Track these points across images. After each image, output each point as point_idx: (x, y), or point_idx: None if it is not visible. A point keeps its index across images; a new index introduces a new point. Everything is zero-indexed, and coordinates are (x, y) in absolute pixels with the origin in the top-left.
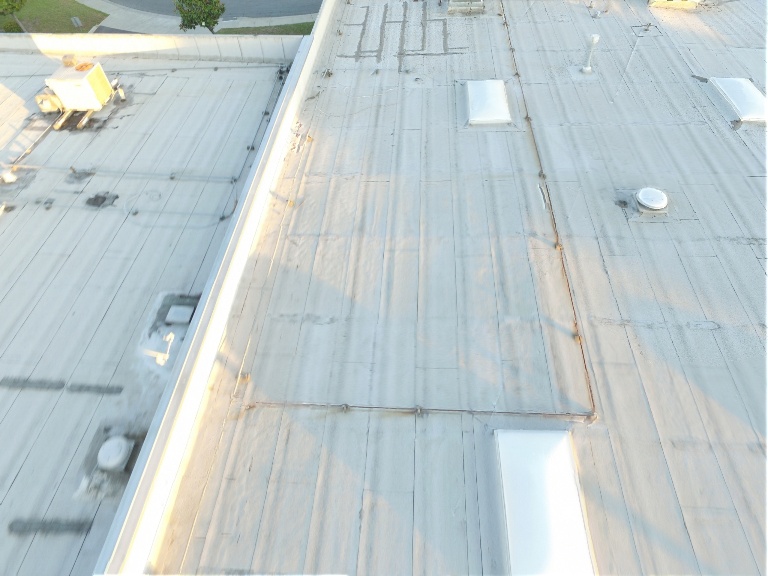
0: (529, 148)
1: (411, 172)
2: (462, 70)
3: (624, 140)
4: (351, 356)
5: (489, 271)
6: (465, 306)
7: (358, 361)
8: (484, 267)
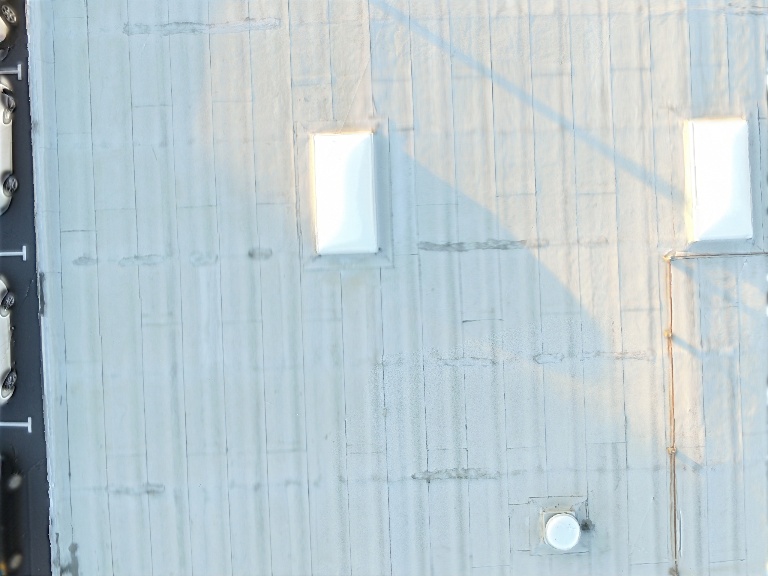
0: None
1: None
2: None
3: None
4: None
5: (746, 412)
6: None
7: None
8: (751, 417)
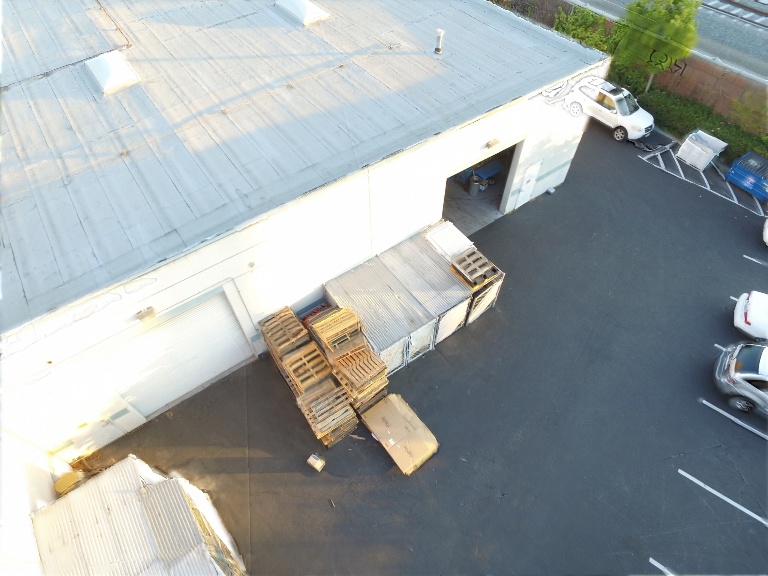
0: None
1: (5, 13)
2: None
3: None
4: (1, 76)
5: (68, 27)
6: (59, 41)
7: (6, 76)
8: (64, 27)
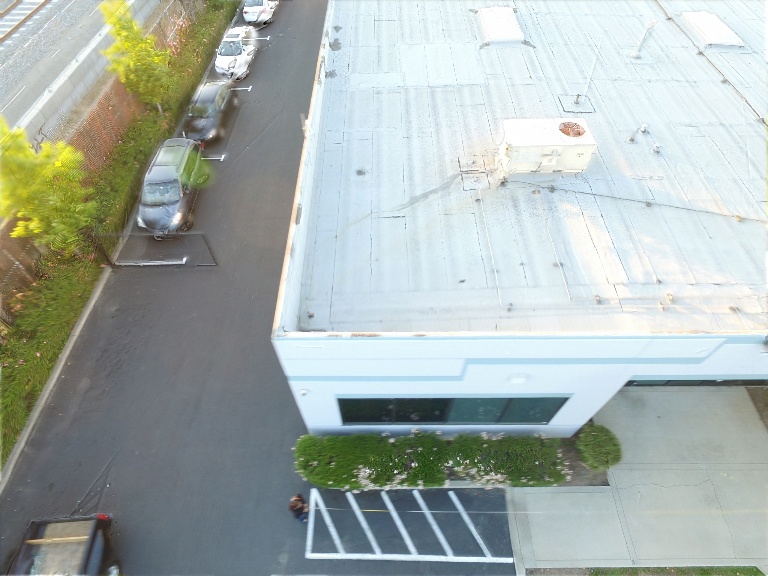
0: (659, 1)
1: None
2: (759, 62)
3: (594, 5)
4: None
5: None
6: None
7: None
8: None
